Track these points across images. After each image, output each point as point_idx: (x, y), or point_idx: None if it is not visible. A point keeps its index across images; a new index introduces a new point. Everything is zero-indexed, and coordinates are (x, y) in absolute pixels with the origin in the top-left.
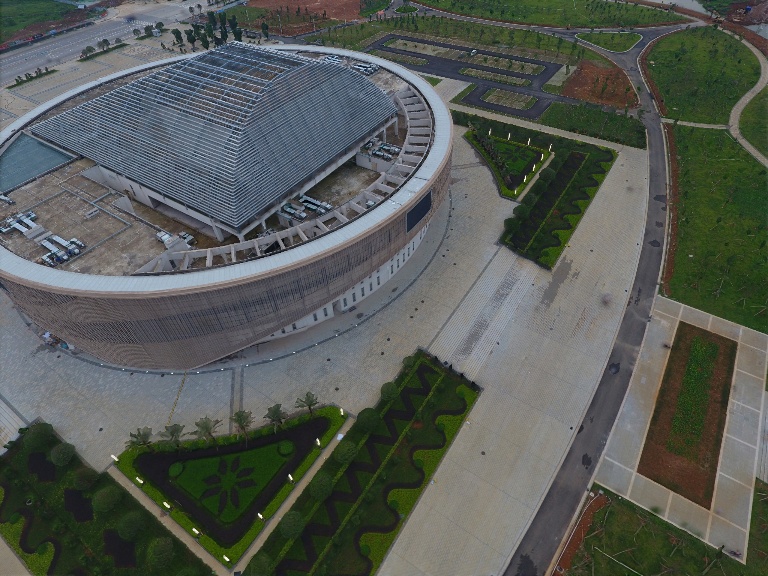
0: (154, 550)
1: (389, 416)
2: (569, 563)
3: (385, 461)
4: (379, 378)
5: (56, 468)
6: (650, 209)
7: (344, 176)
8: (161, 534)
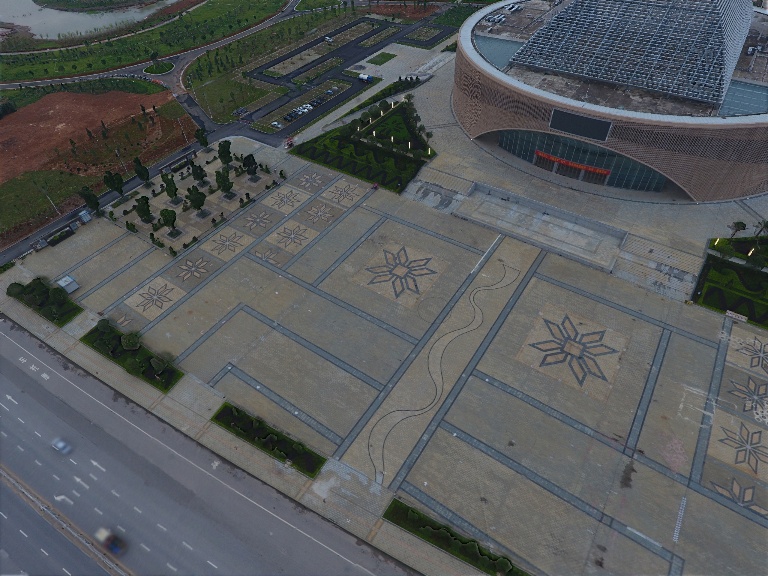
0: None
1: None
2: None
3: None
4: None
5: None
6: None
7: None
8: None
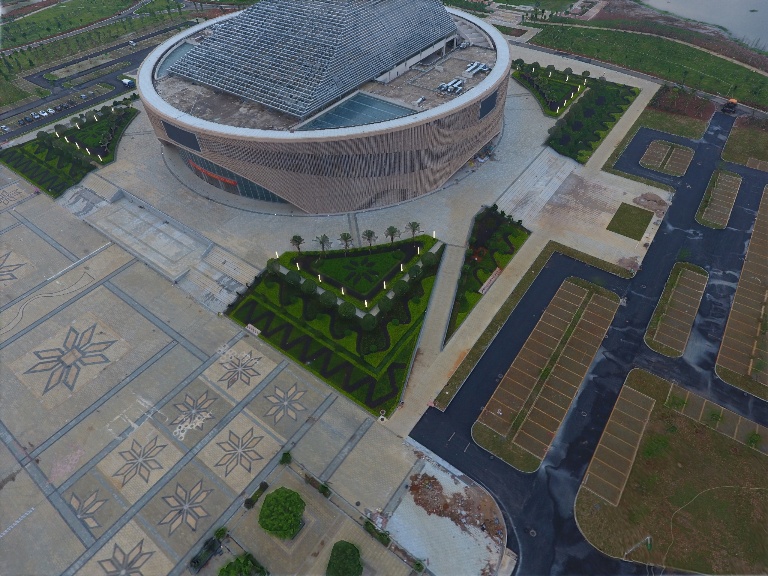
0: None
1: None
2: None
3: None
4: None
5: (565, 134)
6: None
7: None
8: None
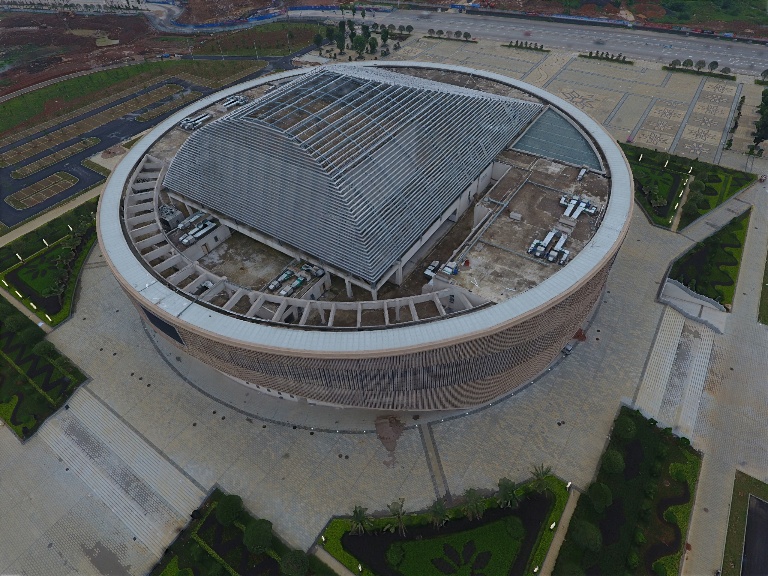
0: (15, 241)
1: (36, 356)
2: None
3: (6, 356)
4: (76, 347)
5: None
6: None
7: (281, 262)
8: (38, 248)
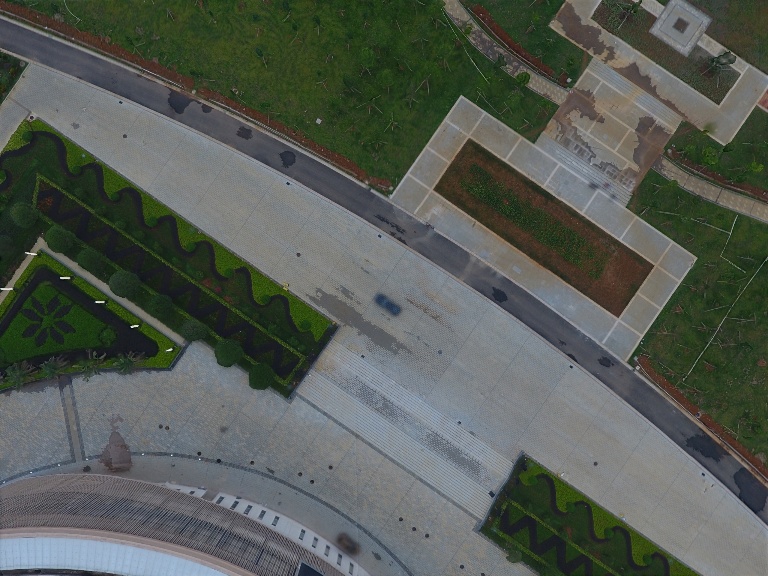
0: None
1: (565, 568)
2: (695, 407)
3: (609, 570)
4: None
5: None
6: (206, 131)
7: None
8: None
